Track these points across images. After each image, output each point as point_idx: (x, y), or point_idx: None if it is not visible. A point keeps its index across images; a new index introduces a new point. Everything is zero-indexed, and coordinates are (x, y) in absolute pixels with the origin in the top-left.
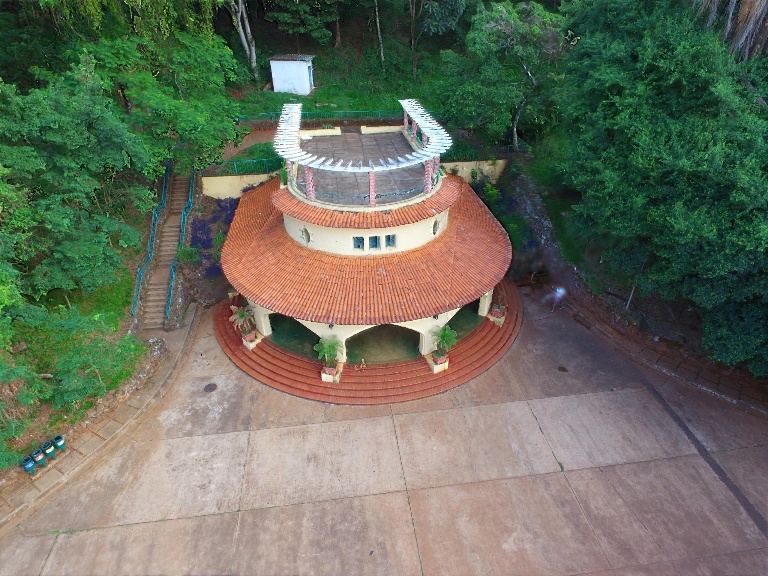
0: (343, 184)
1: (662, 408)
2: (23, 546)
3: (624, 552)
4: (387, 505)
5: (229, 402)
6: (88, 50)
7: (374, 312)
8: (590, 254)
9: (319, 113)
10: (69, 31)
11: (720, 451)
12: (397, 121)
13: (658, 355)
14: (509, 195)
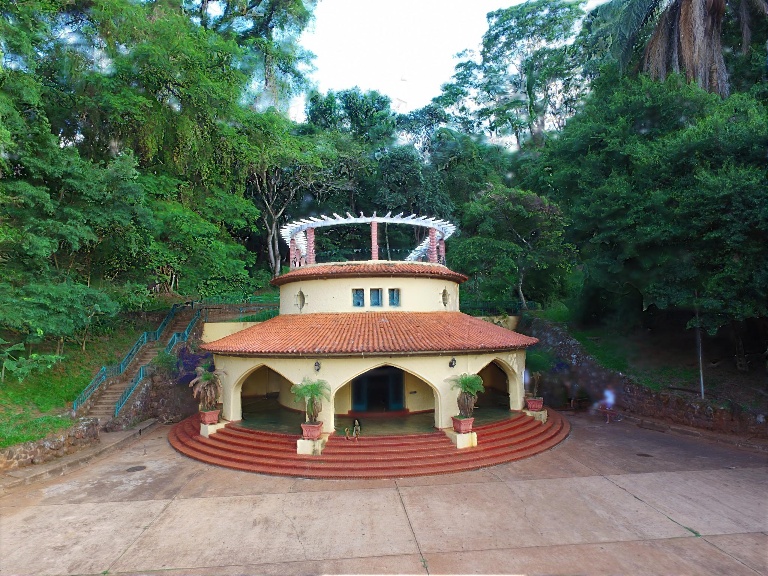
0: None
1: None
2: None
3: None
4: (384, 569)
5: (156, 478)
6: None
7: (373, 344)
8: (633, 361)
9: None
10: None
11: None
12: None
13: None
14: None
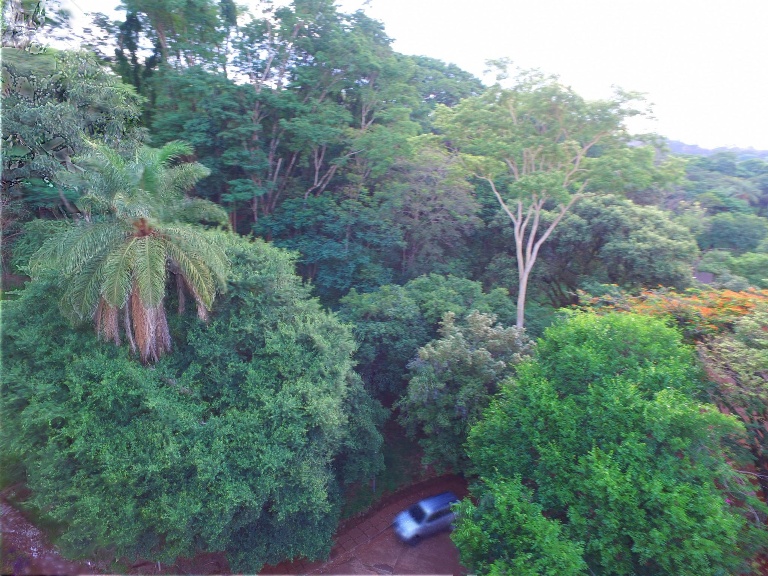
0: None
1: None
2: None
3: None
4: None
5: None
6: None
7: None
8: None
9: None
10: None
11: None
12: None
13: None
14: None
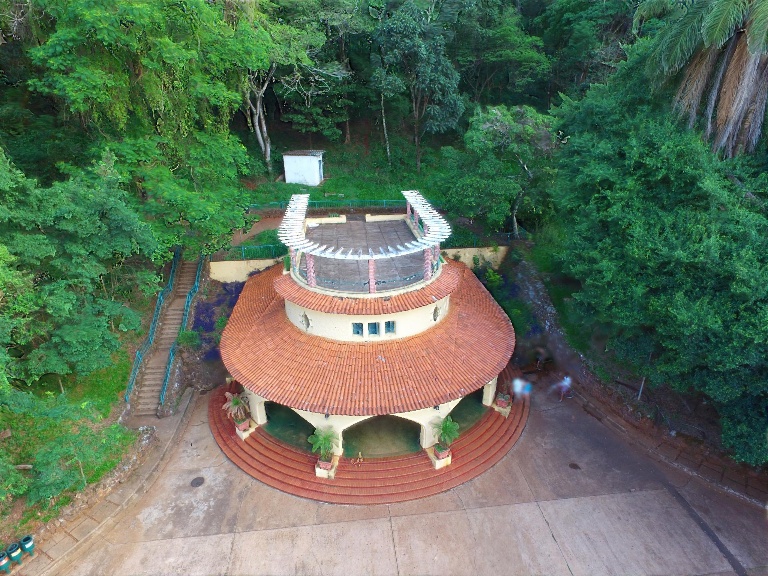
0: (345, 270)
1: (687, 514)
2: None
3: None
4: None
5: (216, 499)
6: (111, 148)
7: (372, 402)
8: (596, 341)
9: (327, 202)
10: (97, 132)
11: (758, 568)
12: (401, 210)
13: (677, 451)
14: (511, 280)
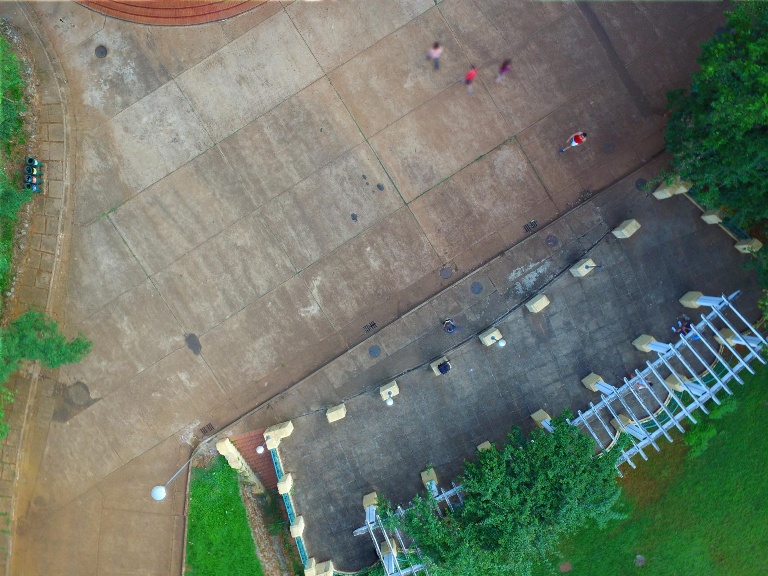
0: None
1: None
2: (92, 231)
3: (482, 55)
4: (317, 93)
5: (132, 59)
6: None
7: None
8: None
9: None
10: None
11: None
12: None
13: None
14: None
